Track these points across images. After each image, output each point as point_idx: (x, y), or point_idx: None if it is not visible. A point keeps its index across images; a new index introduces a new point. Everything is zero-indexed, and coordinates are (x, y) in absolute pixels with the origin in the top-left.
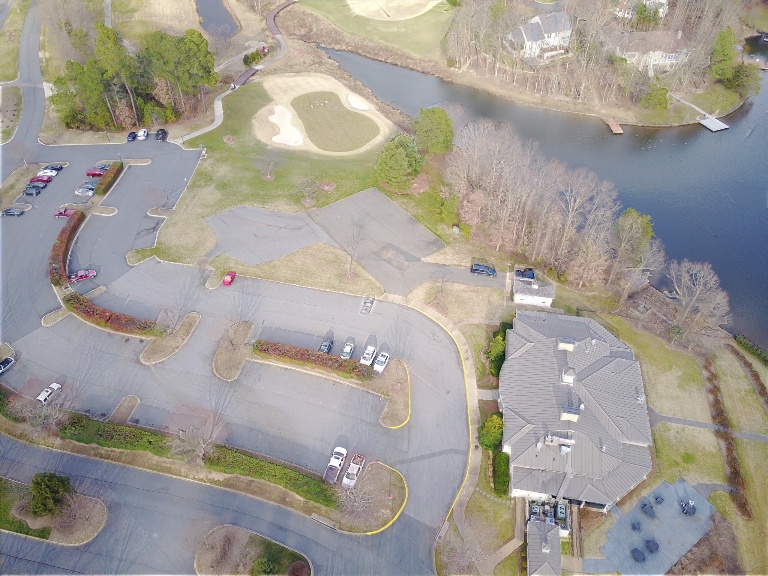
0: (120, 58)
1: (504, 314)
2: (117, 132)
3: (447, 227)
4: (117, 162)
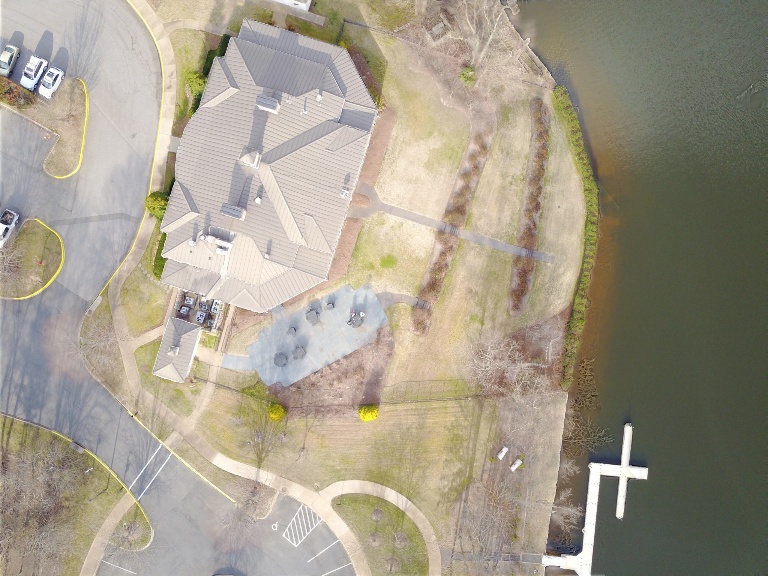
0: None
1: (237, 17)
2: None
3: None
4: None
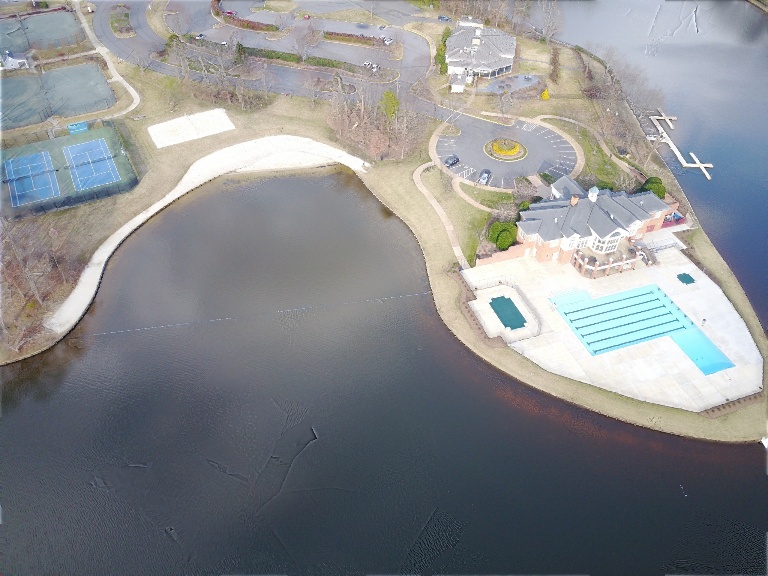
0: None
1: None
2: None
3: (426, 7)
4: None
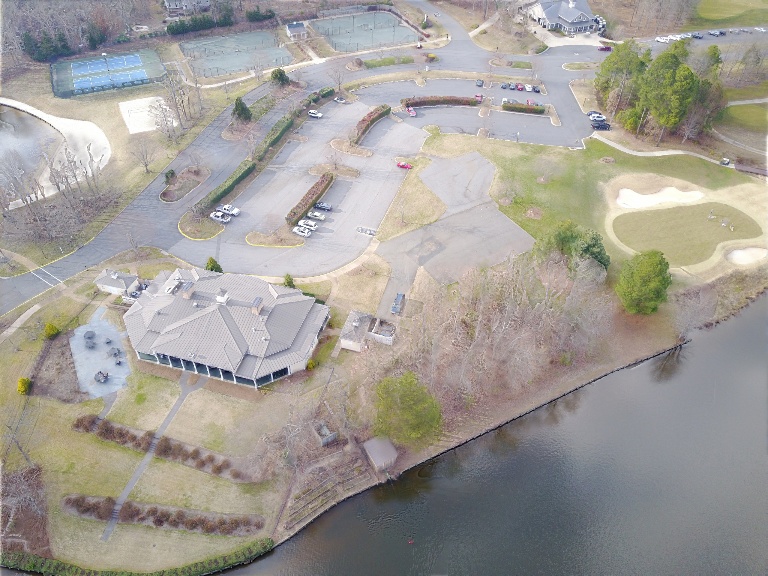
0: (625, 51)
1: (338, 310)
2: (601, 108)
3: None
4: (543, 107)
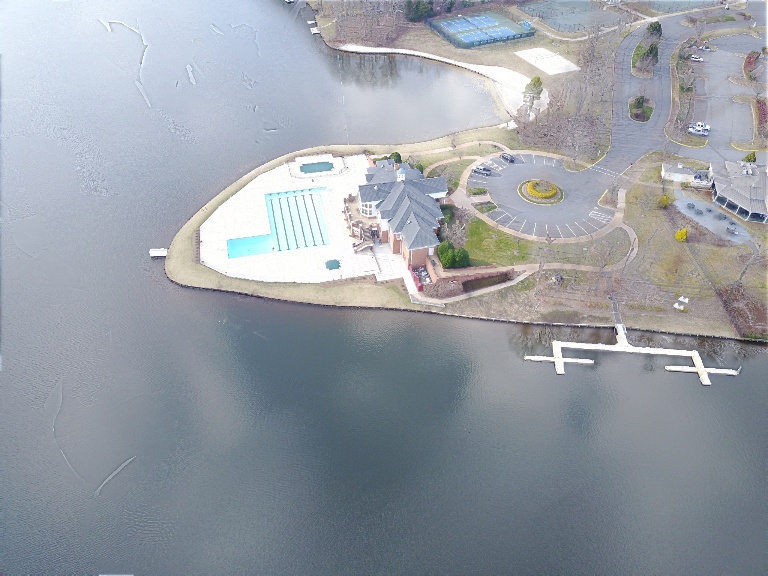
0: None
1: None
2: None
3: None
4: None
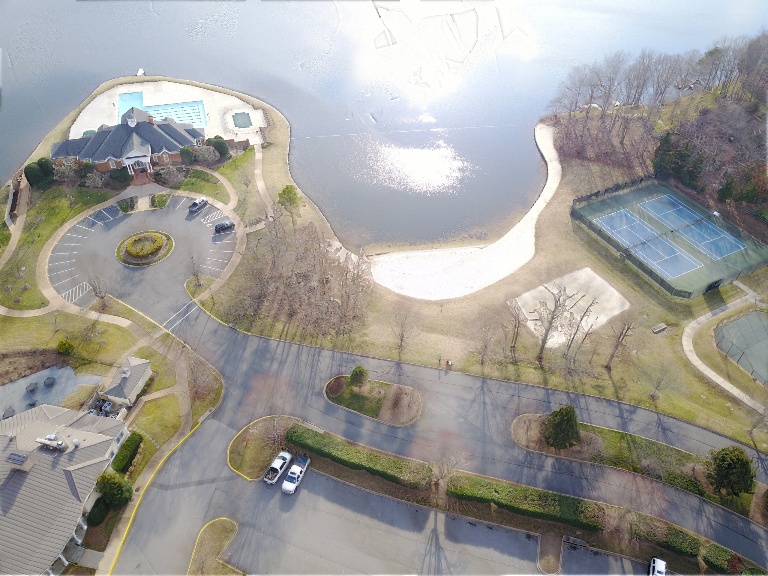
0: None
1: None
2: None
3: None
4: None
